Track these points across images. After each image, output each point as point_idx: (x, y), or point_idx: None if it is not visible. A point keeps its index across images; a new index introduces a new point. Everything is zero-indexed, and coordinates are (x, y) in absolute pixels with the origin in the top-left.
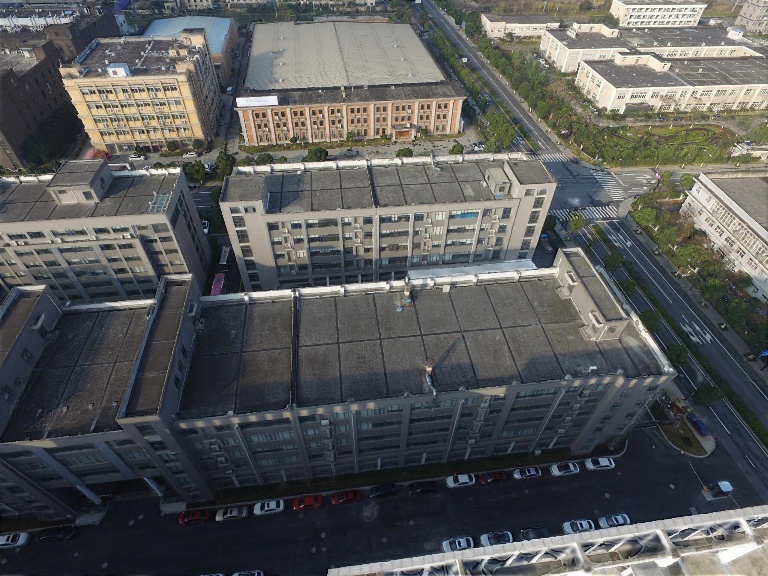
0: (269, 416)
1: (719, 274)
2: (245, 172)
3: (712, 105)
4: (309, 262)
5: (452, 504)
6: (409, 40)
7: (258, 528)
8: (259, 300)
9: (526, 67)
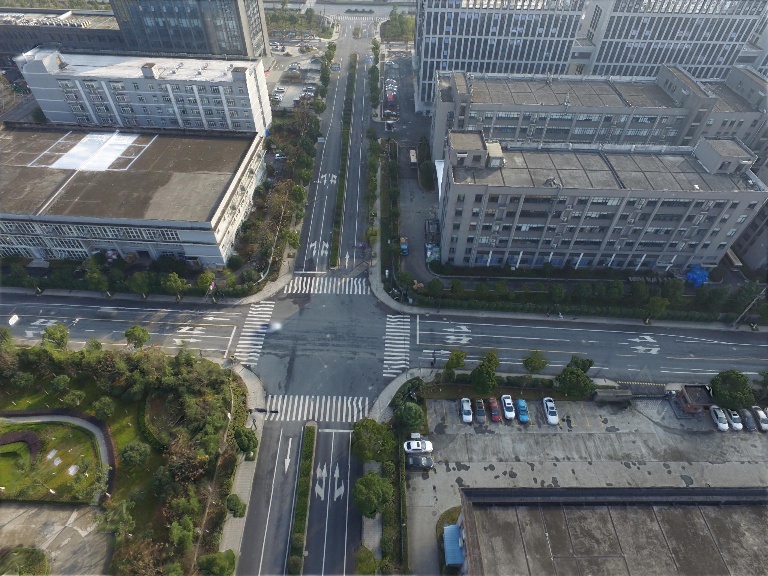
0: (618, 79)
1: None
2: (757, 196)
3: None
4: None
5: None
6: None
7: None
8: None
9: None
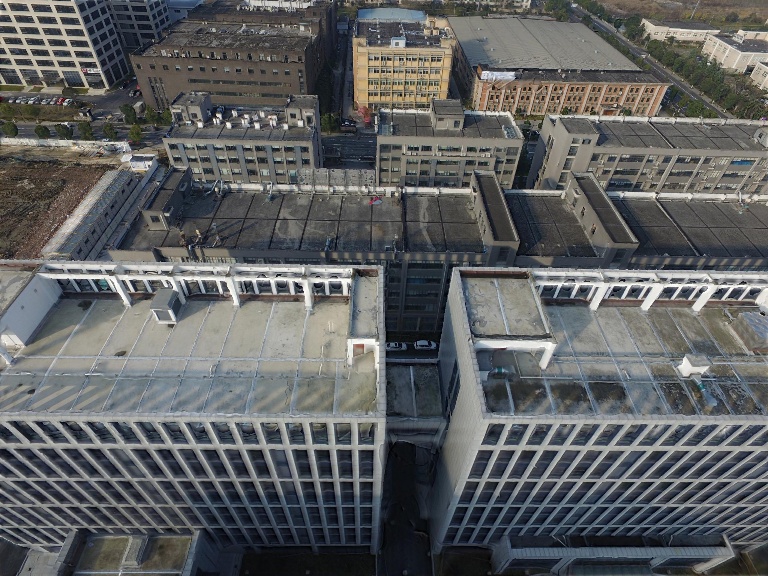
0: (690, 261)
1: None
2: (552, 119)
3: None
4: None
5: None
6: (591, 37)
7: None
8: (628, 199)
9: (700, 66)
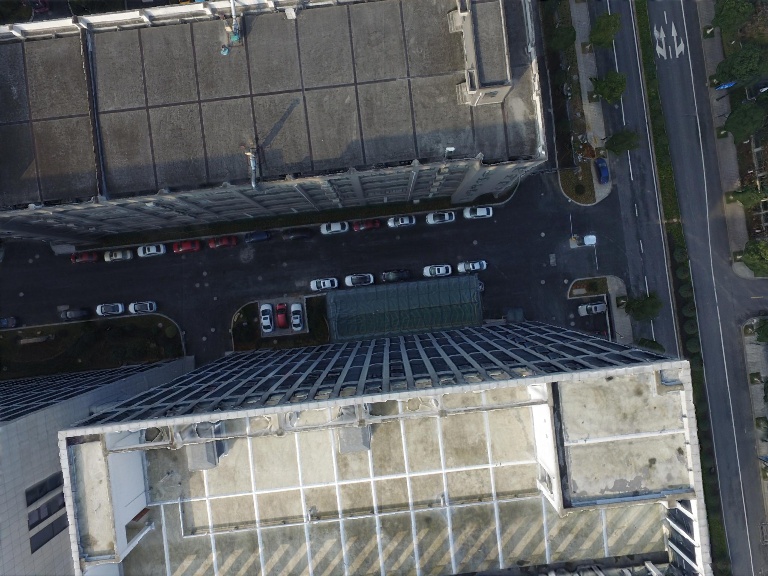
0: (78, 207)
1: None
2: None
3: None
4: None
5: (324, 248)
6: None
7: (145, 267)
8: (37, 34)
9: None
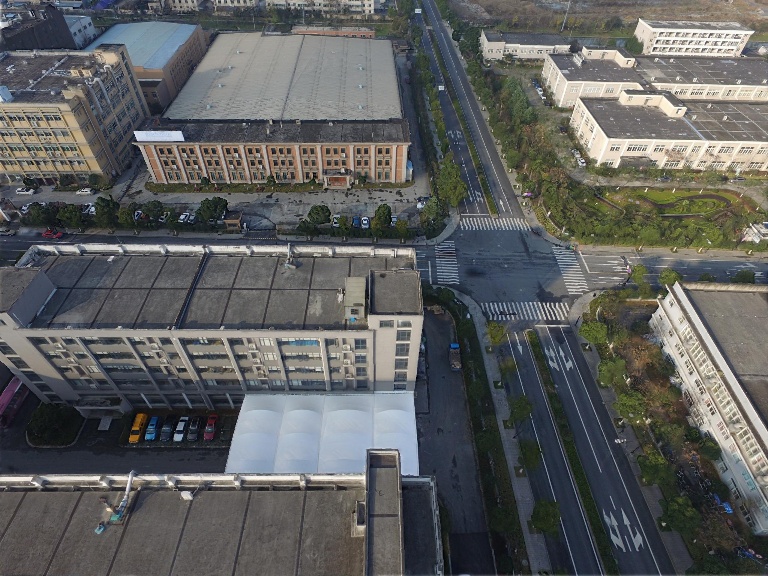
0: None
1: (672, 441)
2: (48, 251)
3: (734, 164)
4: (107, 378)
5: None
6: (381, 61)
7: None
8: None
9: (513, 100)
